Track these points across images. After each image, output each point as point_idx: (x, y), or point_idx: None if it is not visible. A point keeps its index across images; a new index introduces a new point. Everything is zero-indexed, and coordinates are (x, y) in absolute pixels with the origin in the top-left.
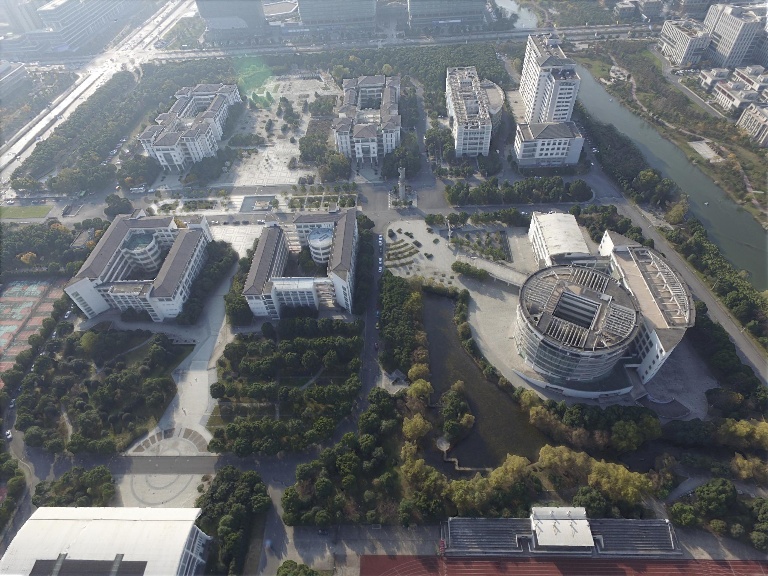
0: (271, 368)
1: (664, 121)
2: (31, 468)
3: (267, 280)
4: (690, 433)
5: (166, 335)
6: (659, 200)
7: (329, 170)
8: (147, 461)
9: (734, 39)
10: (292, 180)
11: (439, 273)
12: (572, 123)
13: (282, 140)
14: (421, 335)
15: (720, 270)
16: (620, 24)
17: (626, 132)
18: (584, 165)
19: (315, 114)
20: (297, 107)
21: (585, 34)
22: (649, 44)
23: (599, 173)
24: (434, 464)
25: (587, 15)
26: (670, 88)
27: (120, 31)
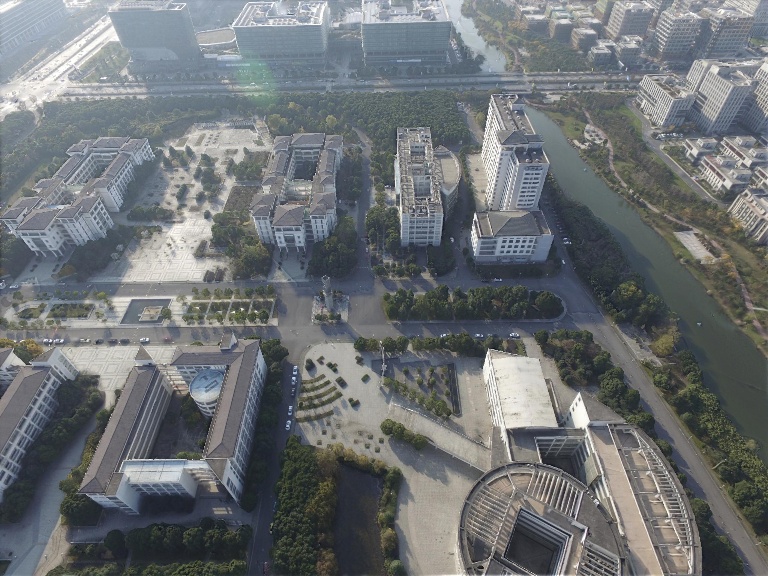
0: None
1: (646, 202)
2: None
3: (119, 464)
4: None
5: None
6: (644, 324)
7: (242, 265)
8: None
9: (721, 103)
10: (196, 275)
11: (365, 433)
12: (540, 212)
13: (195, 214)
14: (325, 561)
15: (723, 439)
16: (595, 71)
17: (603, 214)
18: (554, 263)
19: (240, 178)
20: (220, 167)
21: (557, 82)
22: (627, 98)
23: (571, 275)
24: None
25: (559, 59)
26: (651, 158)
27: (33, 56)
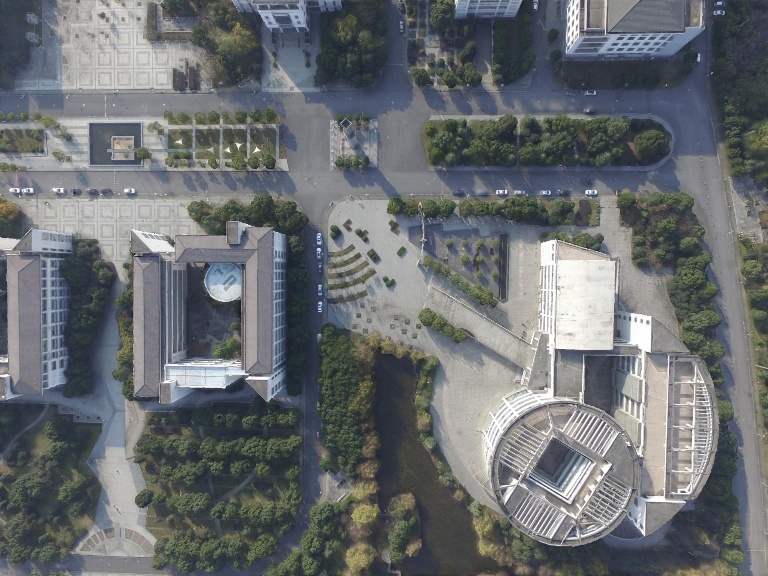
0: (197, 482)
1: None
2: None
3: (162, 369)
4: (636, 569)
5: (61, 410)
6: None
7: (221, 68)
8: (98, 561)
9: None
10: (161, 77)
11: (402, 317)
12: None
13: None
14: (370, 445)
15: None
16: None
17: None
18: (682, 60)
19: None
20: None
21: None
22: None
23: (701, 84)
24: (378, 573)
25: None
26: None
27: None
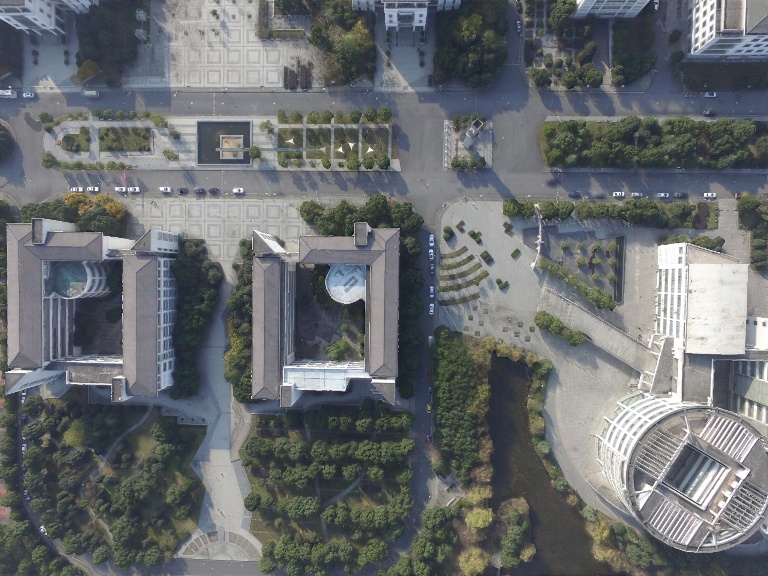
0: None
1: None
2: (88, 566)
3: (281, 372)
4: (753, 575)
5: (165, 411)
6: None
7: (338, 67)
8: (201, 564)
9: None
10: (271, 76)
11: (515, 320)
12: None
13: None
14: (486, 449)
15: None
16: None
17: None
18: None
19: None
20: None
21: None
22: None
23: None
24: None
25: None
26: None
27: None
